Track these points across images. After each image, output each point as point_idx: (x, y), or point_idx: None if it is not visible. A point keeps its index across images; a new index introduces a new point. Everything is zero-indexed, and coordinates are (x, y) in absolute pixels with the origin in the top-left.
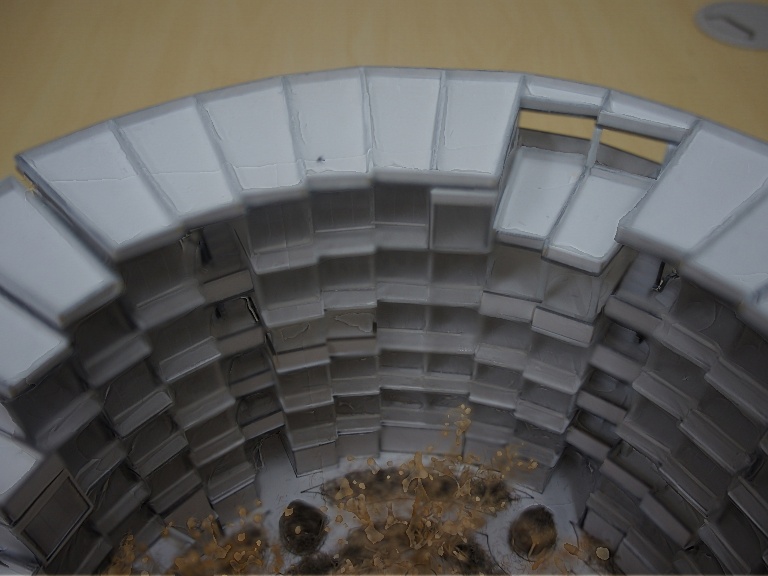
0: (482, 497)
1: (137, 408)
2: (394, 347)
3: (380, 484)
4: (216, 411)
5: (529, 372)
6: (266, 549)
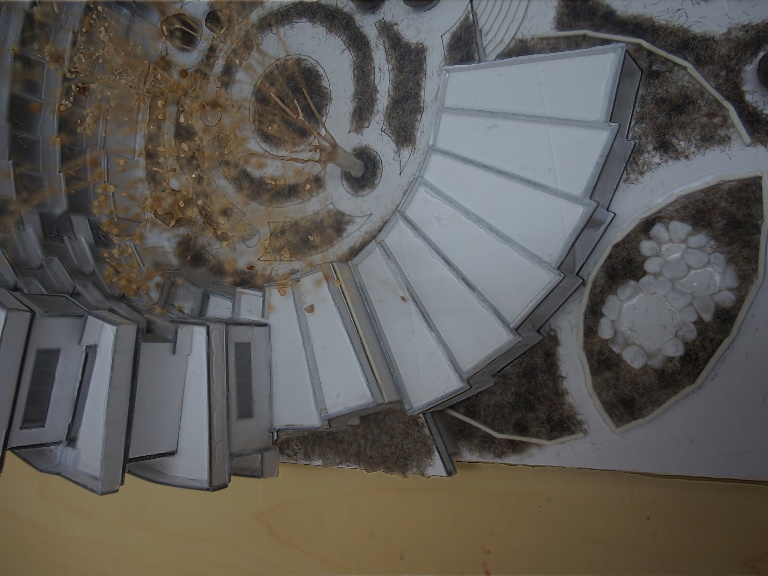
0: (164, 76)
1: (0, 273)
2: (5, 113)
3: (152, 155)
4: (34, 238)
5: (23, 5)
6: (190, 236)
